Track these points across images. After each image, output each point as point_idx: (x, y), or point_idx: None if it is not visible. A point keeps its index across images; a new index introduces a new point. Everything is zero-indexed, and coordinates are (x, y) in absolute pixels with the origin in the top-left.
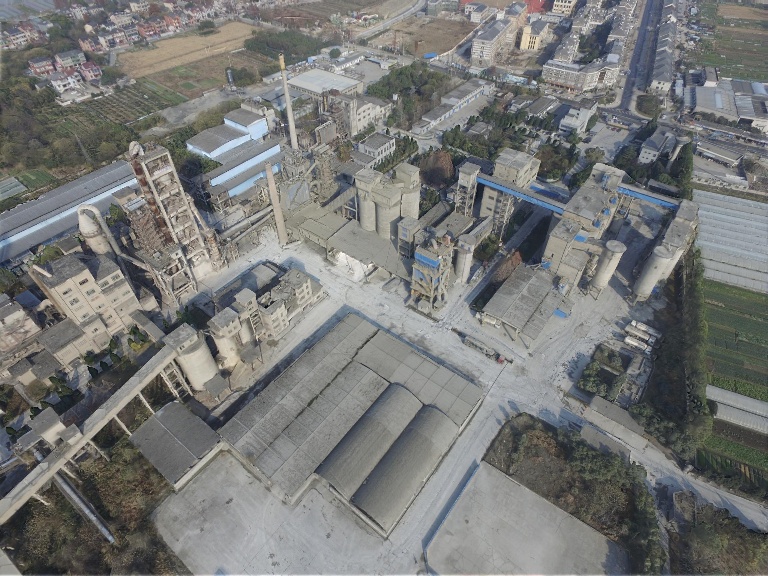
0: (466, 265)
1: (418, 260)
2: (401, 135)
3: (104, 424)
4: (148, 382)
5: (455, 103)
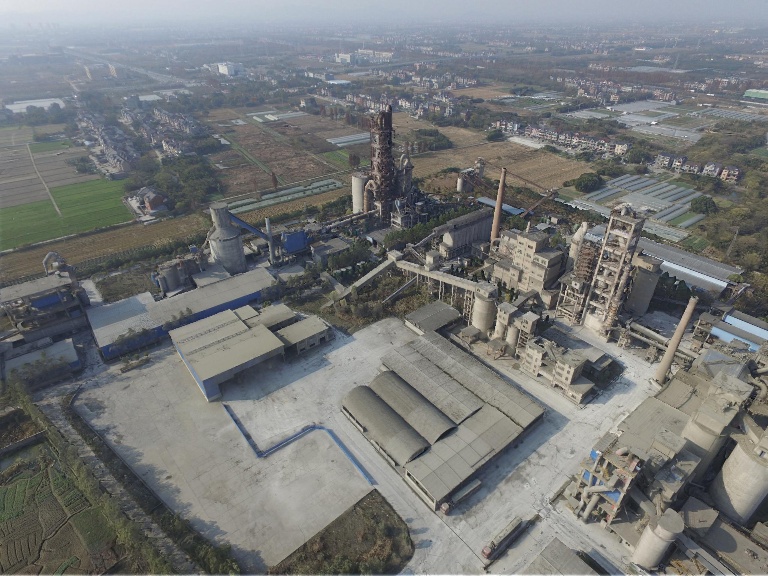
0: (644, 541)
1: None
2: None
3: (436, 278)
4: (459, 286)
5: None
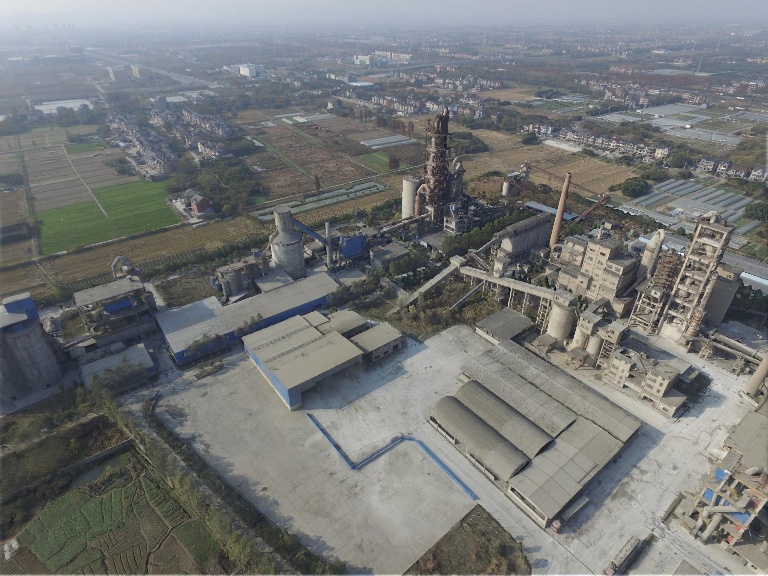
0: None
1: None
2: None
3: (507, 285)
4: (533, 294)
5: None
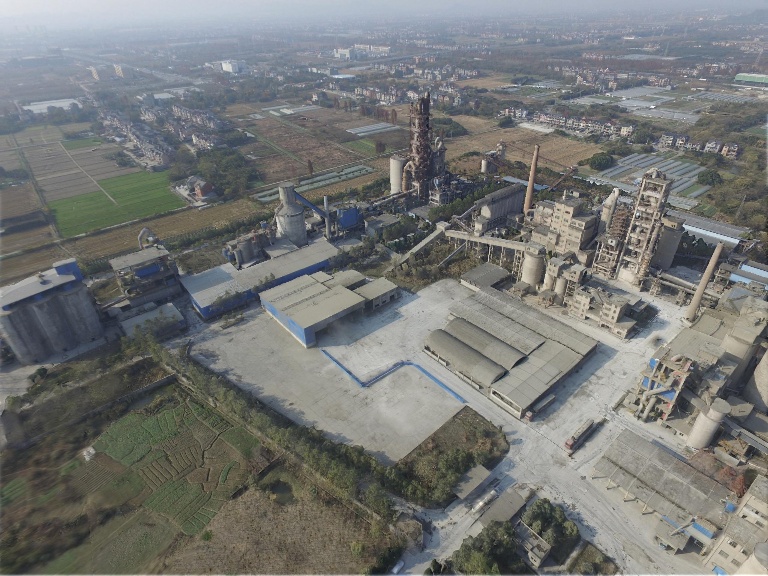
0: (697, 427)
1: None
2: None
3: (486, 243)
4: (509, 247)
5: None
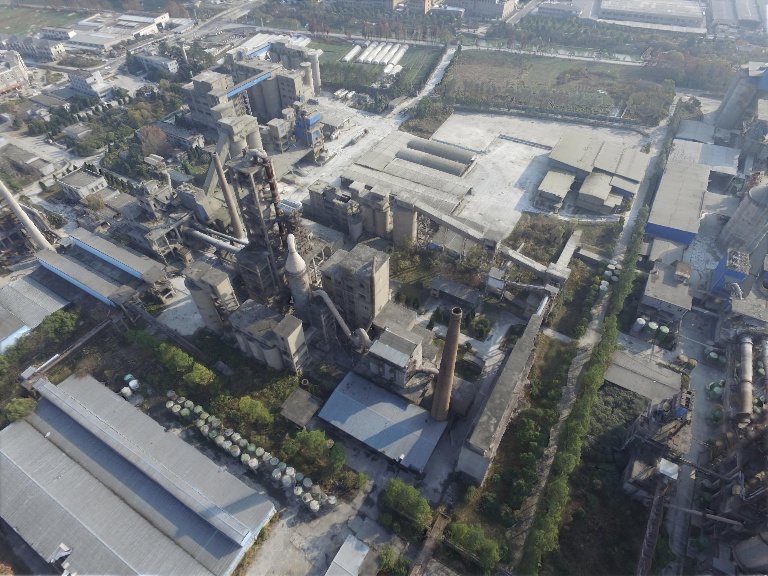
0: None
1: (311, 125)
2: (47, 183)
3: None
4: None
5: (6, 141)
